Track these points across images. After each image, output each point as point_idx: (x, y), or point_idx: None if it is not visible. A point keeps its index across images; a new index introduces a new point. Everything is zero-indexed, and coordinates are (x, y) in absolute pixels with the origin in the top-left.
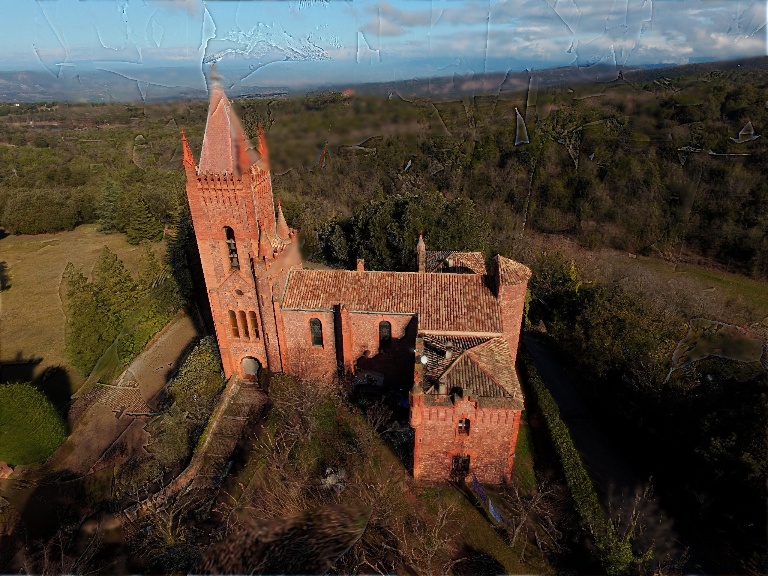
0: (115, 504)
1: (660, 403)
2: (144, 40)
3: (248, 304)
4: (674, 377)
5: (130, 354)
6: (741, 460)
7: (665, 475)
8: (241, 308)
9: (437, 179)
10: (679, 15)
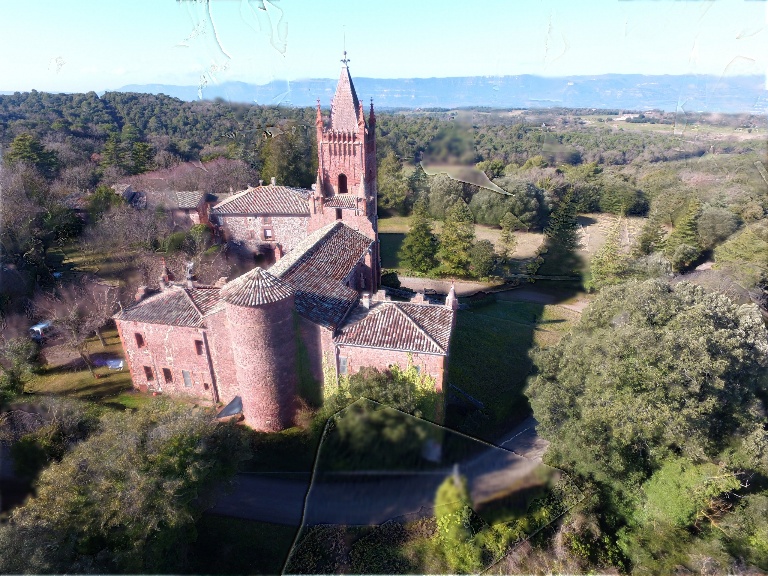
0: (190, 234)
1: None
2: (740, 27)
3: None
4: None
5: (423, 272)
6: None
7: None
8: None
9: None
10: None
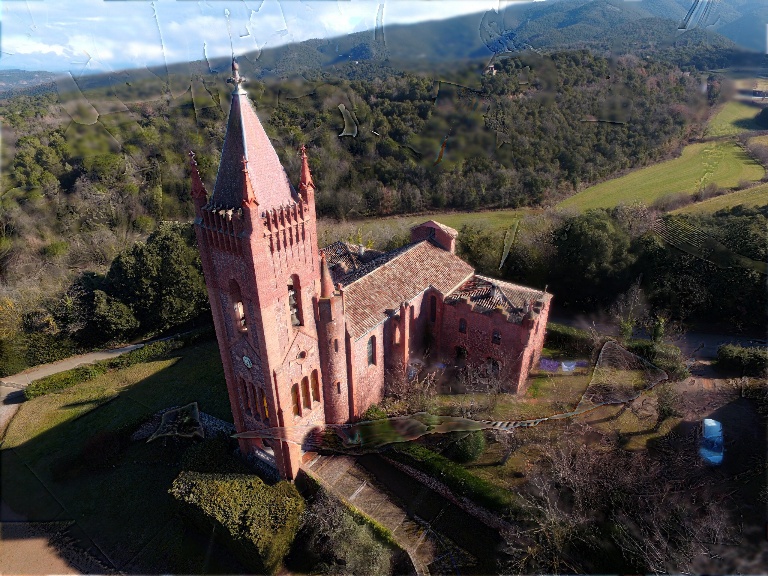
0: None
1: (544, 269)
2: None
3: (310, 364)
4: (543, 251)
5: None
6: (602, 268)
7: (553, 308)
8: (304, 374)
9: (126, 207)
10: (344, 30)
